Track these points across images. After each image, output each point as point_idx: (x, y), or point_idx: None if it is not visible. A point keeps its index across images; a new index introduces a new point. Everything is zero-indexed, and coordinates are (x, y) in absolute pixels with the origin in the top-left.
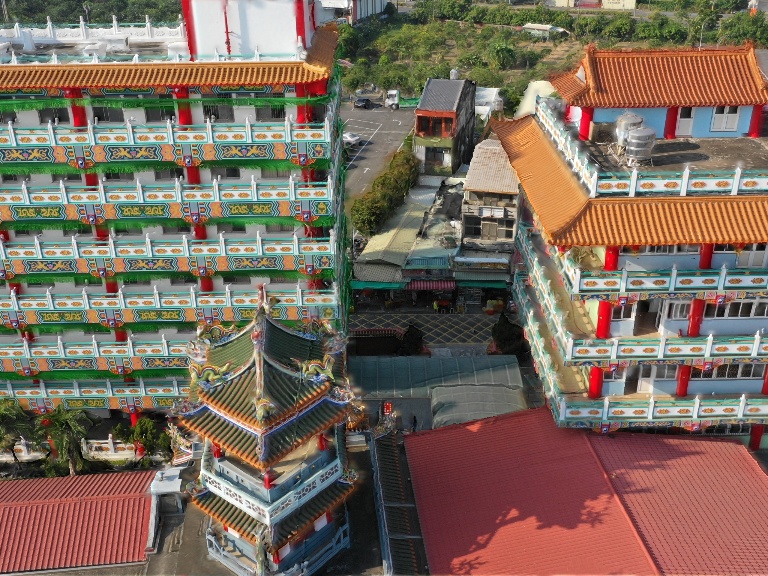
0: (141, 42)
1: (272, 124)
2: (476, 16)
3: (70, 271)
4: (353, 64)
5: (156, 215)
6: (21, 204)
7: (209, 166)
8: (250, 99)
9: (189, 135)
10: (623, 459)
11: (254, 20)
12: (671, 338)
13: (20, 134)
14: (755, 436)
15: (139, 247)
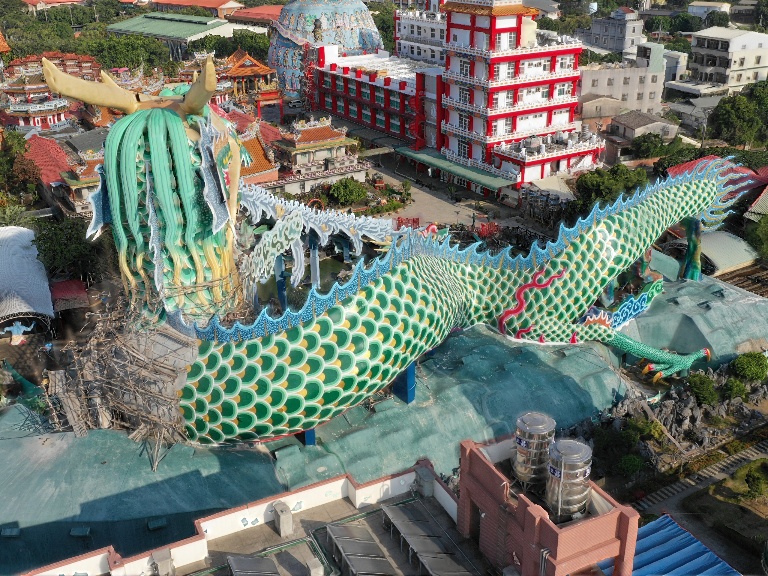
0: None
1: None
2: None
3: None
4: None
5: None
6: None
7: None
8: None
9: None
10: None
11: None
12: None
13: None
14: None
15: None
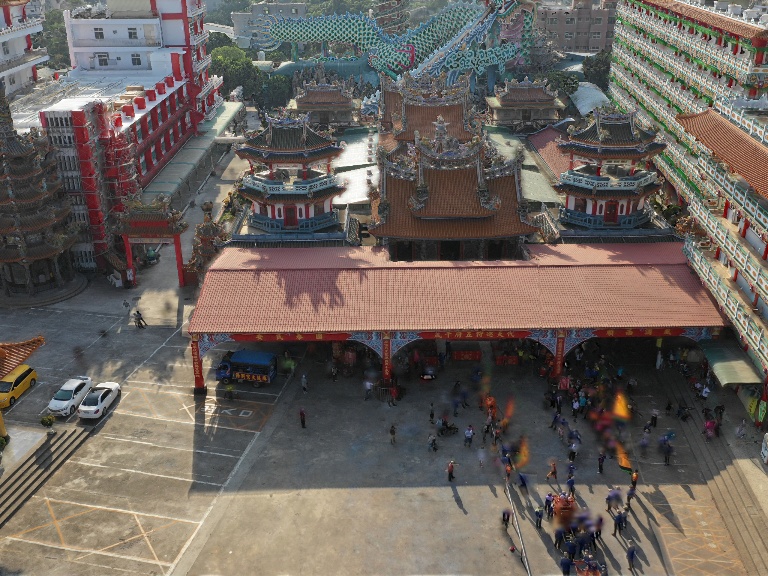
0: None
1: None
2: None
3: None
4: None
5: None
6: None
7: None
8: (749, 46)
9: None
10: (670, 273)
11: None
12: (735, 230)
13: None
14: None
15: None
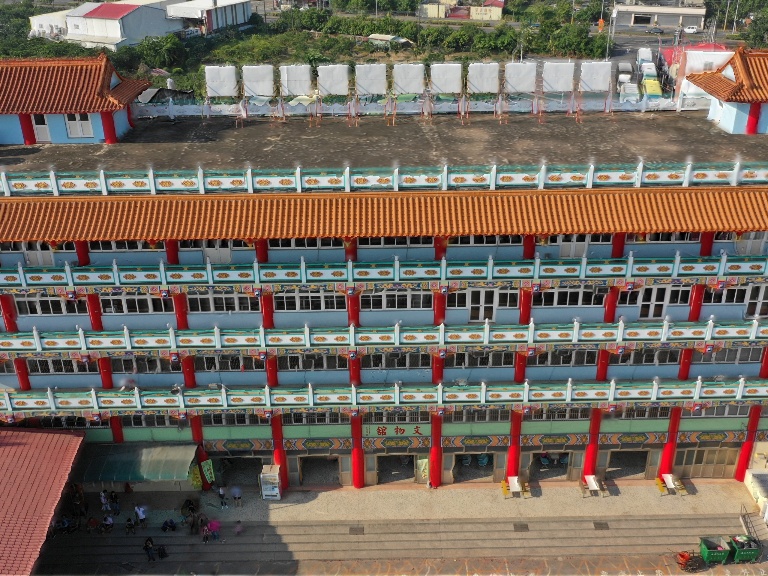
0: None
1: None
2: (332, 26)
3: None
4: (170, 73)
5: None
6: None
7: None
8: None
9: None
10: None
11: None
12: None
13: None
14: (115, 429)
15: None
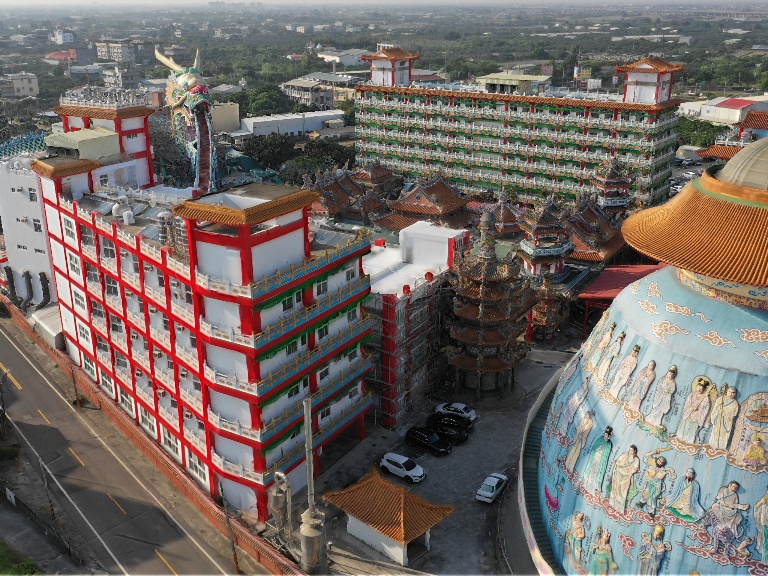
0: (613, 99)
1: (639, 122)
2: None
3: (572, 160)
4: None
5: (601, 145)
6: (565, 138)
7: (619, 133)
8: (635, 114)
9: (615, 123)
10: None
11: (643, 93)
12: None
13: (570, 118)
14: None
15: (593, 155)
